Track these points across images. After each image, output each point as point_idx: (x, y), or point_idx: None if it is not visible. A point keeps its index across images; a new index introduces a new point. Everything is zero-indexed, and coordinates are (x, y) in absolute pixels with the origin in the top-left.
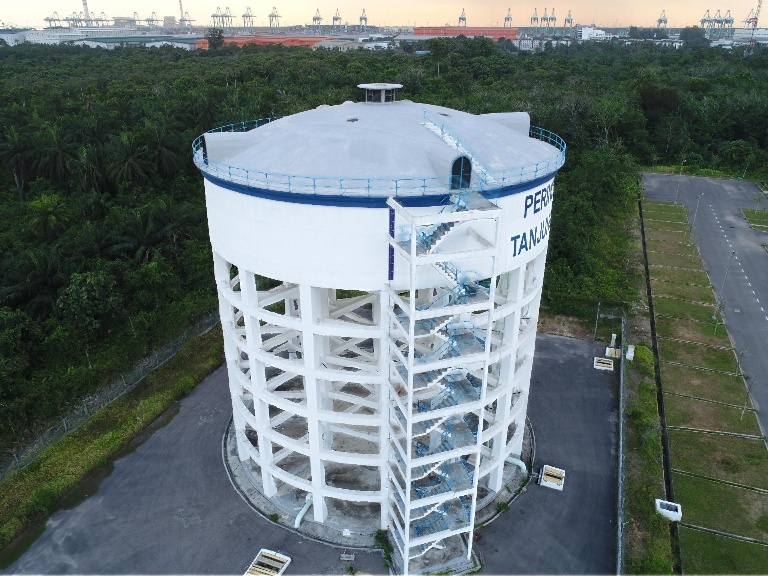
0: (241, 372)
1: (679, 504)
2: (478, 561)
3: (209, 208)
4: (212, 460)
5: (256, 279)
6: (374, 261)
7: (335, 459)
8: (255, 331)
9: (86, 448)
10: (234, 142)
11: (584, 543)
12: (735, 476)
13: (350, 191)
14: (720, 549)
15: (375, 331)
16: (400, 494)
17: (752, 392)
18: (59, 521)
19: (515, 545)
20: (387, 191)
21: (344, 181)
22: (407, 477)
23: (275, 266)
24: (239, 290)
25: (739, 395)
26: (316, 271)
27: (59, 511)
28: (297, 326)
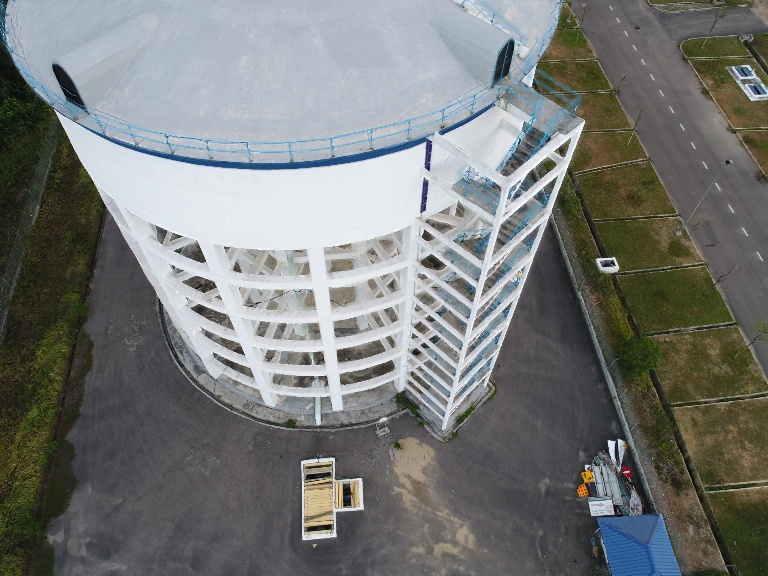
0: (209, 321)
1: (613, 257)
2: (491, 384)
3: (103, 164)
4: (180, 389)
5: (40, 105)
6: (405, 201)
7: (356, 369)
8: (235, 294)
9: (16, 437)
10: (113, 59)
11: (560, 327)
12: (641, 209)
13: (376, 135)
14: (652, 287)
15: (402, 263)
16: (439, 381)
17: (626, 108)
18: (61, 532)
19: (511, 354)
20: (422, 119)
21: (356, 117)
22: (458, 377)
23: (267, 238)
24: (31, 131)
25: (618, 116)
26: (331, 232)
27: (51, 522)
28: (306, 286)
